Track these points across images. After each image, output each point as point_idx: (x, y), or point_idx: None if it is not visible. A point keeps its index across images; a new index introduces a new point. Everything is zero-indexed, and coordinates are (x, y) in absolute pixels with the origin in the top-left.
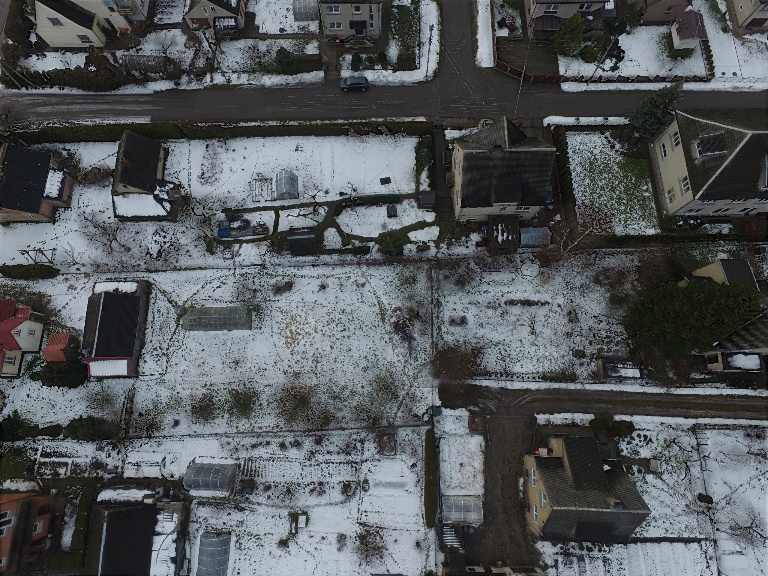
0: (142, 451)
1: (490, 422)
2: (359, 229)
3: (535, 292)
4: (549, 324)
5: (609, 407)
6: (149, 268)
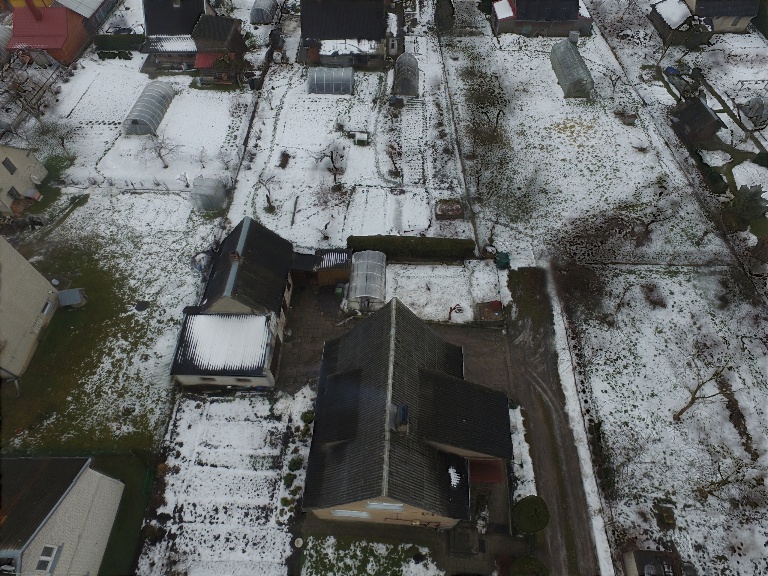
0: (428, 43)
1: (496, 334)
2: (747, 183)
3: (767, 431)
4: (709, 453)
5: (563, 571)
6: (606, 33)
